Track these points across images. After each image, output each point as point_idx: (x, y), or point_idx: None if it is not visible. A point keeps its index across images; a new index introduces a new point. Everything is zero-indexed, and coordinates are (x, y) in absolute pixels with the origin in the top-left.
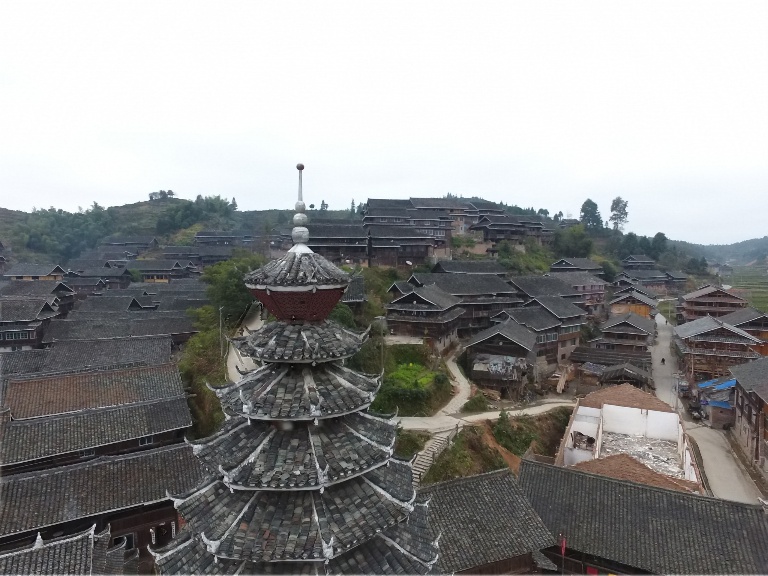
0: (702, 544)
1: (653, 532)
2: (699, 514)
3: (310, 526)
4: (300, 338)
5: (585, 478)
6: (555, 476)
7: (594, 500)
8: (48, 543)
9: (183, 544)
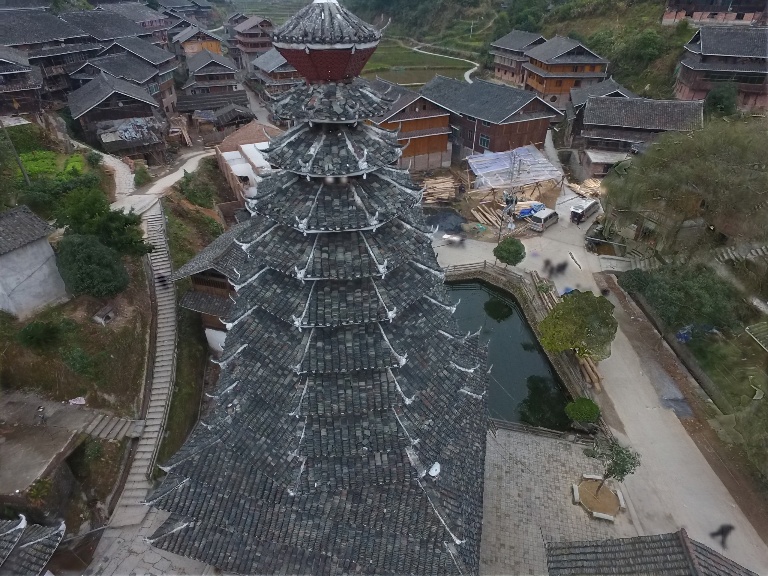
0: None
1: None
2: None
3: (409, 232)
4: (365, 95)
5: None
6: None
7: None
8: None
9: (307, 303)
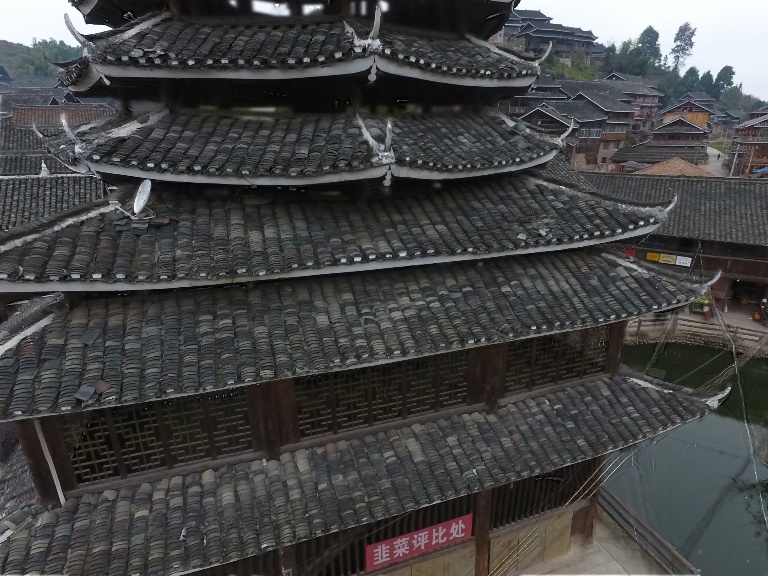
0: (761, 215)
1: (705, 211)
2: (762, 194)
3: None
4: None
5: (631, 179)
6: (597, 180)
7: (640, 194)
8: (55, 174)
9: None
